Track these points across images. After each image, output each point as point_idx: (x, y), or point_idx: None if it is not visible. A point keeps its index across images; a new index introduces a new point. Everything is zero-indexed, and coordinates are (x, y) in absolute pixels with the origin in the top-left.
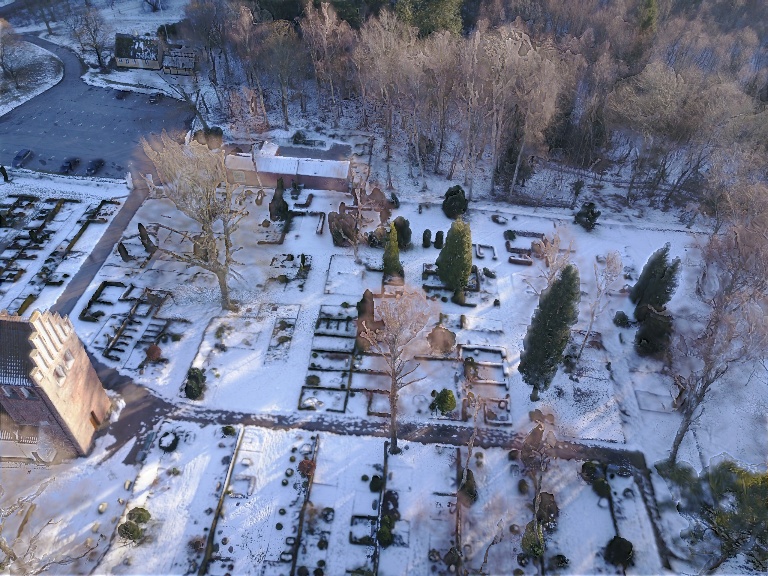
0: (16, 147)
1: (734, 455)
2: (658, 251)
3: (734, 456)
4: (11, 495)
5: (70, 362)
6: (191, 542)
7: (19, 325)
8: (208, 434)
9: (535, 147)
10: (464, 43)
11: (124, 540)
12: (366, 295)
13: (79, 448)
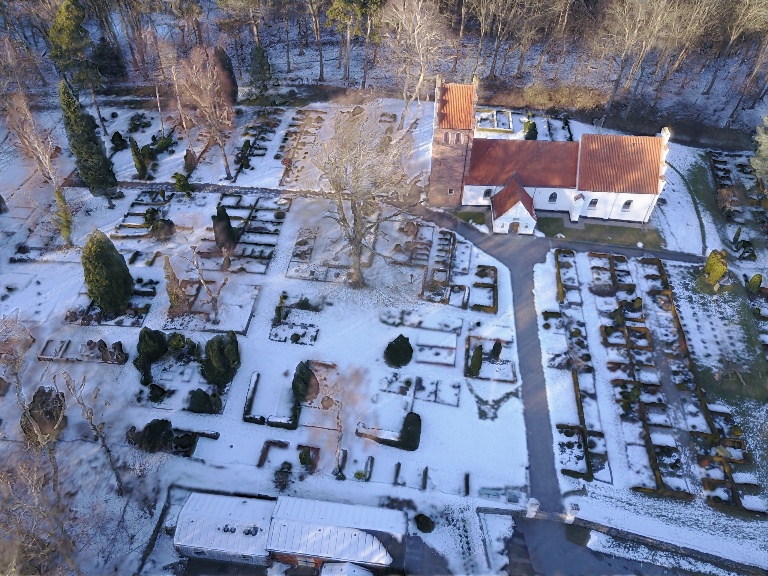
0: None
1: None
2: None
3: None
4: None
5: None
6: None
7: None
8: None
9: None
10: None
11: None
12: None
13: None
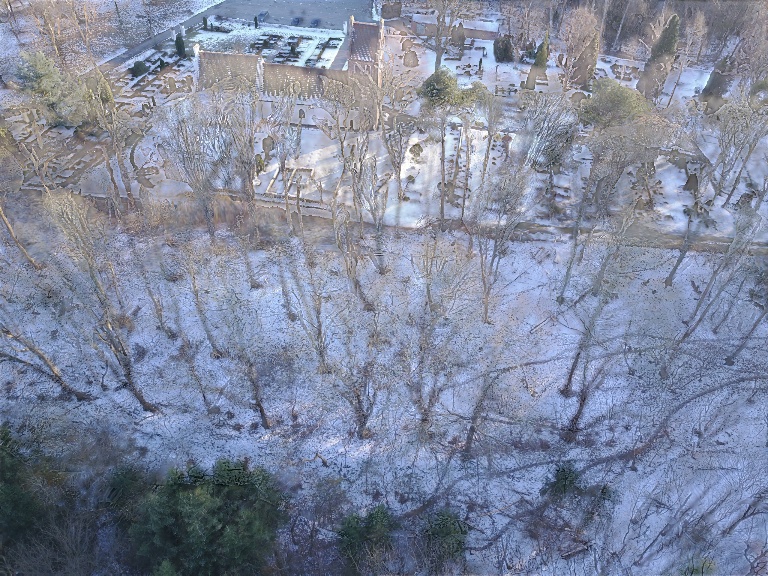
0: (254, 12)
1: (764, 165)
2: (722, 59)
3: (764, 165)
4: None
5: (381, 65)
6: None
7: (371, 27)
8: None
9: (637, 5)
10: None
11: (409, 160)
12: None
13: (375, 123)
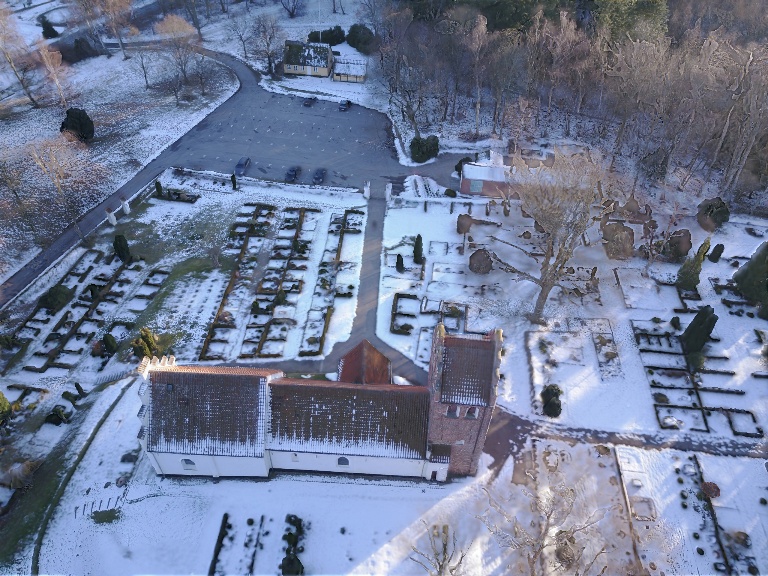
0: (228, 155)
1: None
2: None
3: None
4: (417, 515)
5: None
6: (628, 567)
7: (479, 343)
8: (582, 453)
9: None
10: (669, 52)
11: (553, 564)
12: (706, 311)
13: (473, 467)
